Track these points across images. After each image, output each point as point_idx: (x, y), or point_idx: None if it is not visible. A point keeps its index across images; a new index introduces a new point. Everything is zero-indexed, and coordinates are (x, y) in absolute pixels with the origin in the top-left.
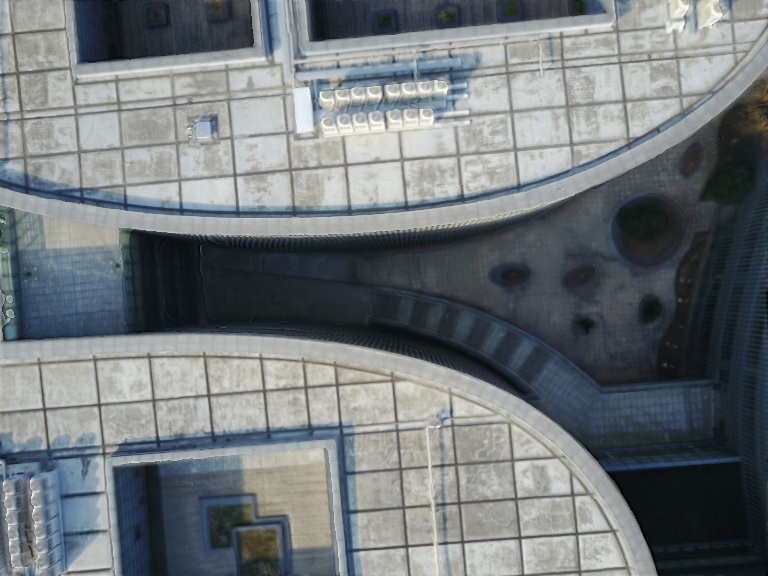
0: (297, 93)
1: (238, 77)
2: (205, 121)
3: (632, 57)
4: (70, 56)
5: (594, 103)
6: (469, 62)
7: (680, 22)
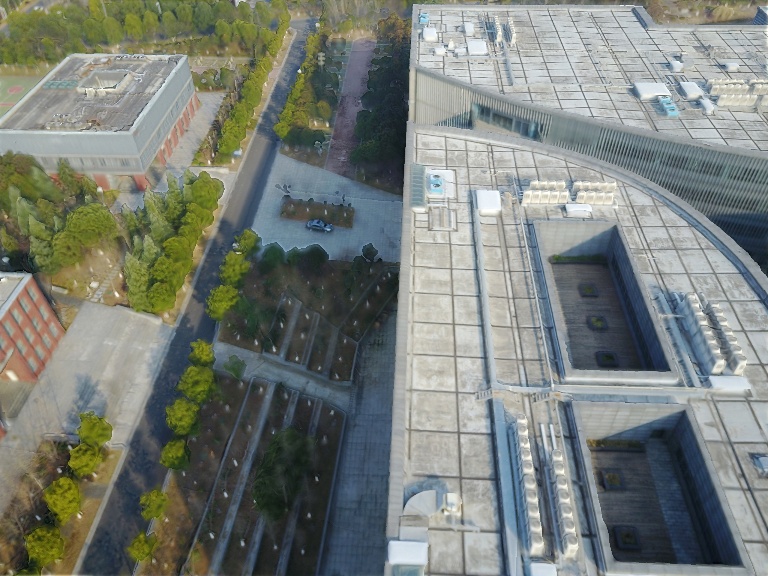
0: (716, 384)
1: (708, 433)
2: (760, 462)
3: (635, 222)
4: (738, 575)
5: (670, 238)
6: (657, 291)
7: (615, 200)
